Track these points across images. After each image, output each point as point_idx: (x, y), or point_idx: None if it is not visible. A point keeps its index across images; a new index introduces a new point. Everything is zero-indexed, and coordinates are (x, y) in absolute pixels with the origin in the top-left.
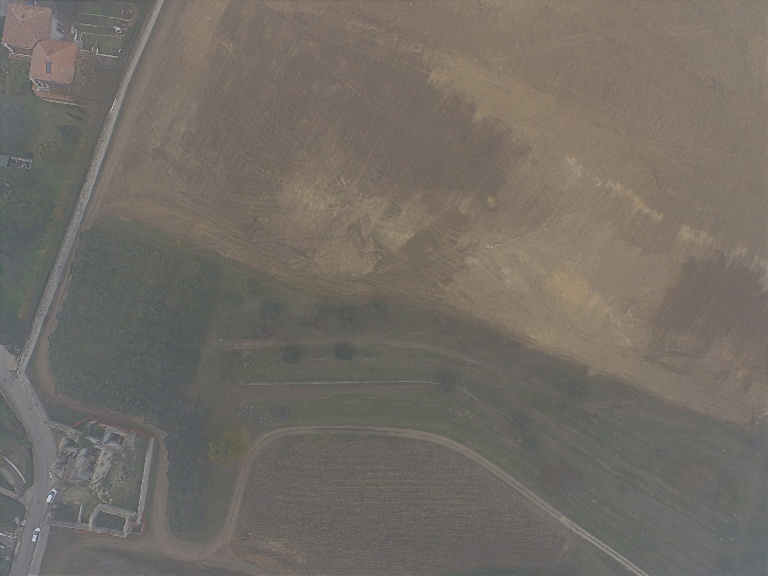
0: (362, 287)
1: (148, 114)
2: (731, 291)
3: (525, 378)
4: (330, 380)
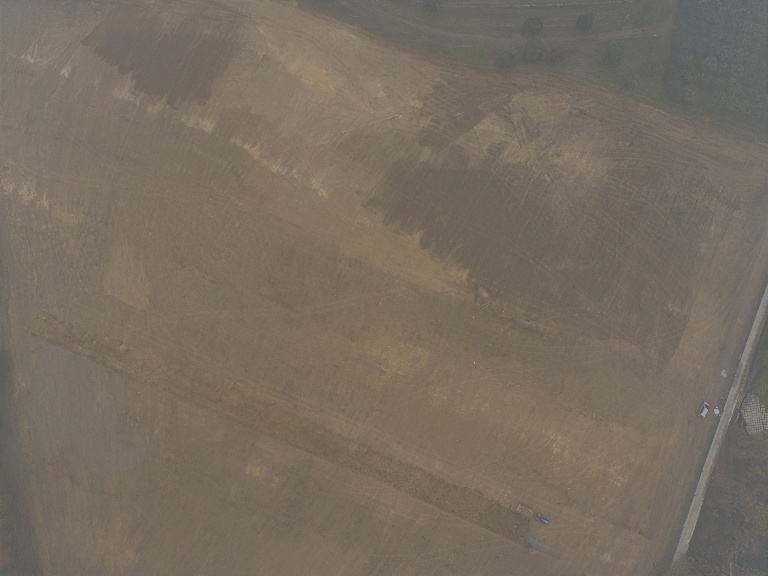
0: (522, 81)
1: (749, 242)
2: (162, 74)
3: (355, 7)
4: (543, 7)
